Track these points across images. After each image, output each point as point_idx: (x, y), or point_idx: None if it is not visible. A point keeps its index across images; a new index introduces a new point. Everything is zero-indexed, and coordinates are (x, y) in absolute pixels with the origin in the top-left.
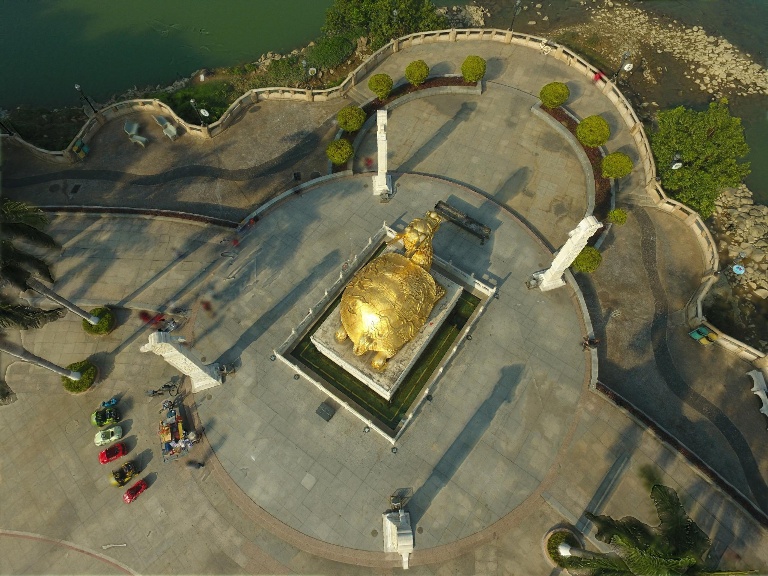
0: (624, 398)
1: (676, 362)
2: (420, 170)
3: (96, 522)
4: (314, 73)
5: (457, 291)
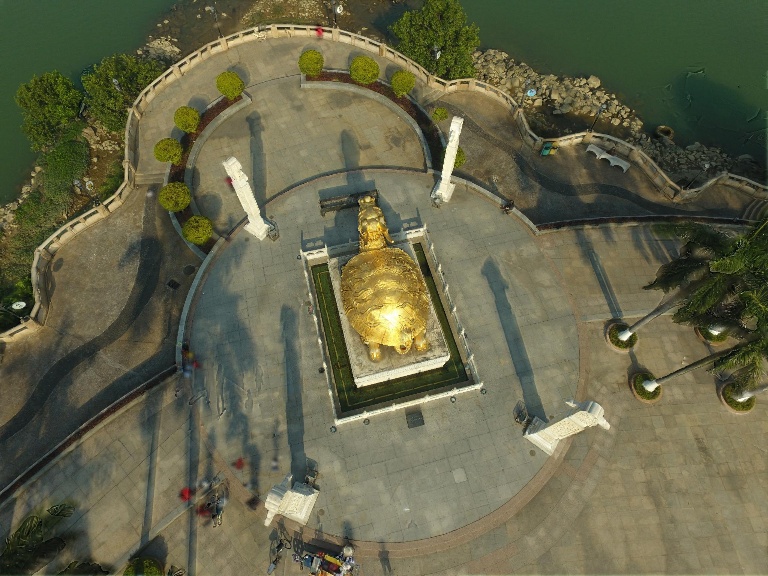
0: (557, 221)
1: (552, 177)
2: (272, 193)
3: None
4: (92, 186)
5: (410, 247)
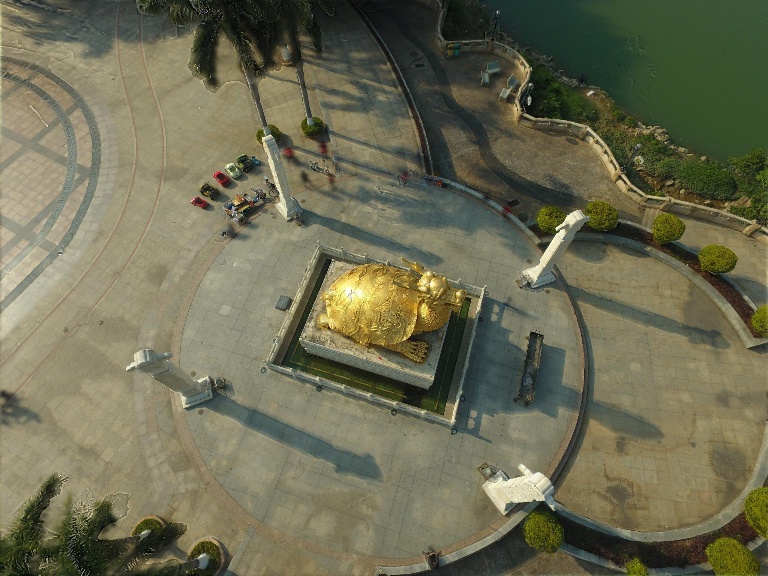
0: None
1: None
2: (583, 309)
3: (177, 190)
4: (639, 163)
5: (427, 375)
